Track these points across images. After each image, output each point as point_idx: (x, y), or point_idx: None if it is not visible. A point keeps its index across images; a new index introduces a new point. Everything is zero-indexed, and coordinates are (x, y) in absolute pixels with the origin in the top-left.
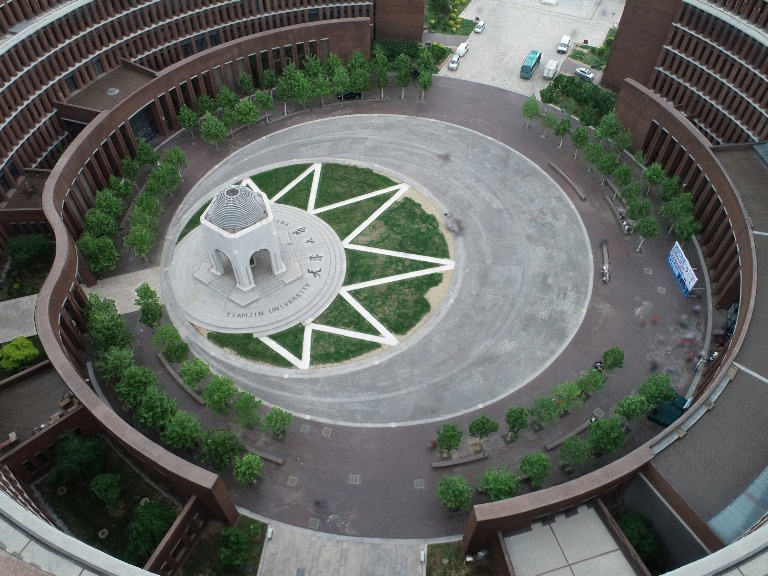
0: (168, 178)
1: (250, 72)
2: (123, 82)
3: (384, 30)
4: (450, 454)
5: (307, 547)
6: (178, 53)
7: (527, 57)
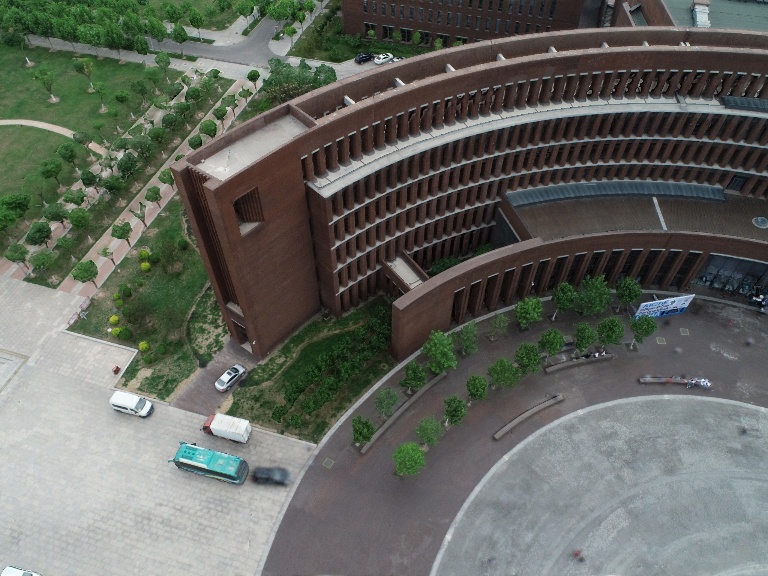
0: None
1: None
2: None
3: None
4: None
5: None
6: None
7: (205, 467)
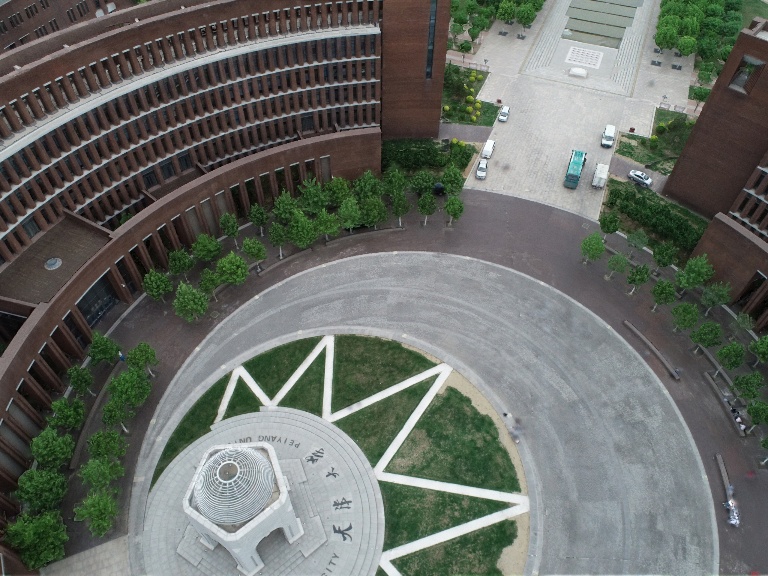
0: (133, 393)
1: (233, 205)
2: (67, 246)
3: (392, 127)
4: None
5: None
6: (139, 185)
7: (571, 161)
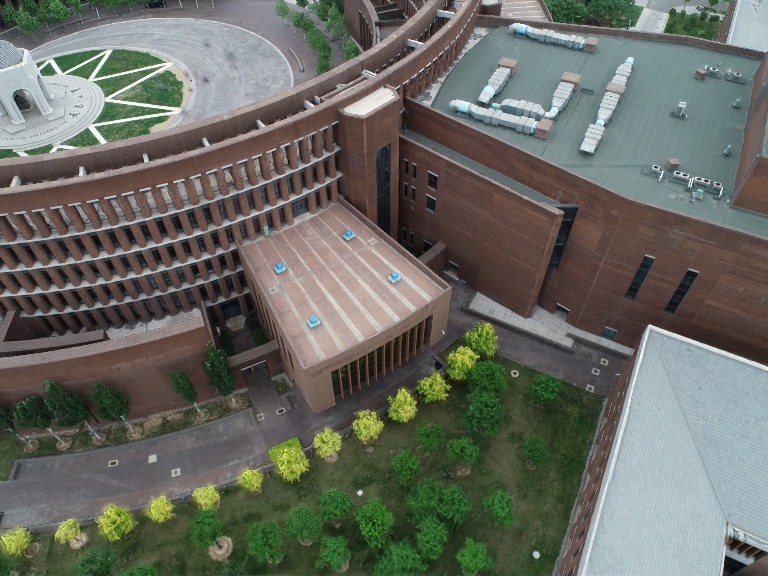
0: None
1: None
2: None
3: None
4: None
5: None
6: None
7: None
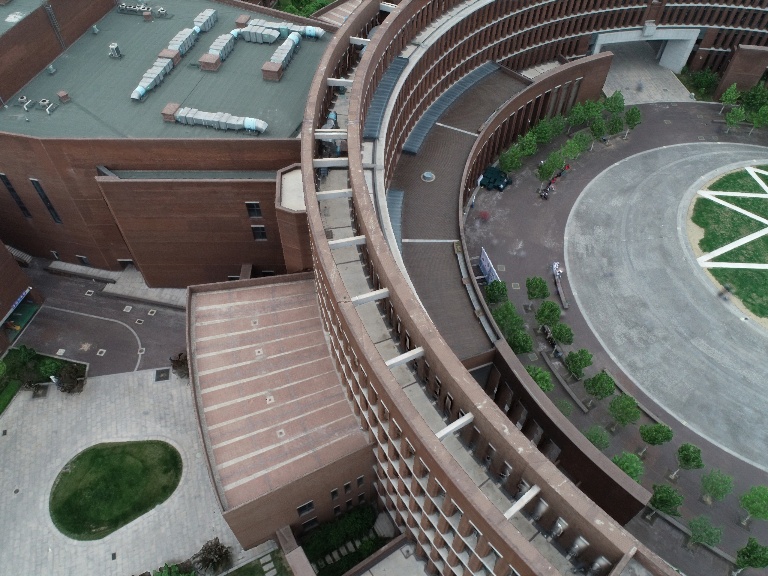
0: None
1: None
2: None
3: None
4: (622, 139)
5: (670, 97)
6: None
7: None
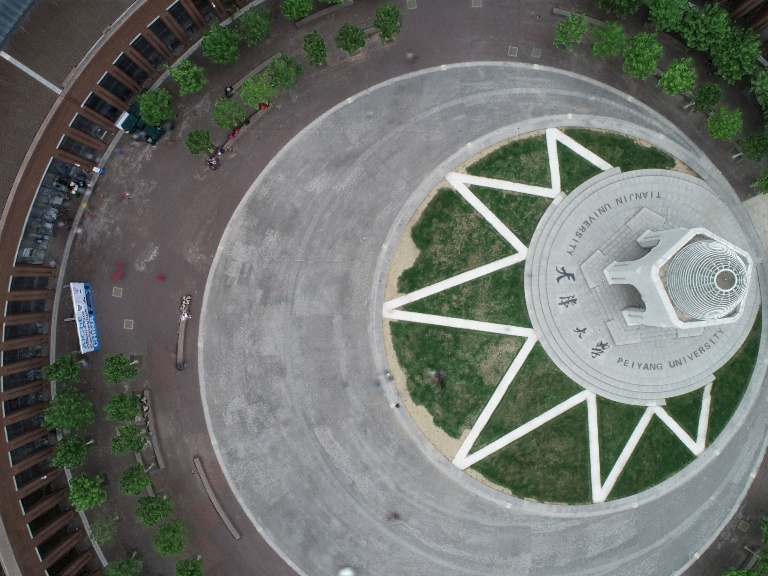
0: None
1: None
2: None
3: None
4: (382, 40)
5: None
6: None
7: None
